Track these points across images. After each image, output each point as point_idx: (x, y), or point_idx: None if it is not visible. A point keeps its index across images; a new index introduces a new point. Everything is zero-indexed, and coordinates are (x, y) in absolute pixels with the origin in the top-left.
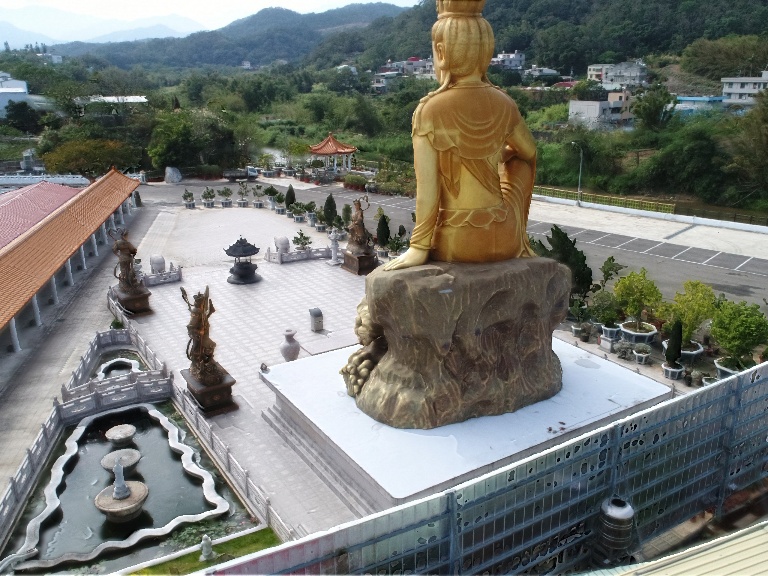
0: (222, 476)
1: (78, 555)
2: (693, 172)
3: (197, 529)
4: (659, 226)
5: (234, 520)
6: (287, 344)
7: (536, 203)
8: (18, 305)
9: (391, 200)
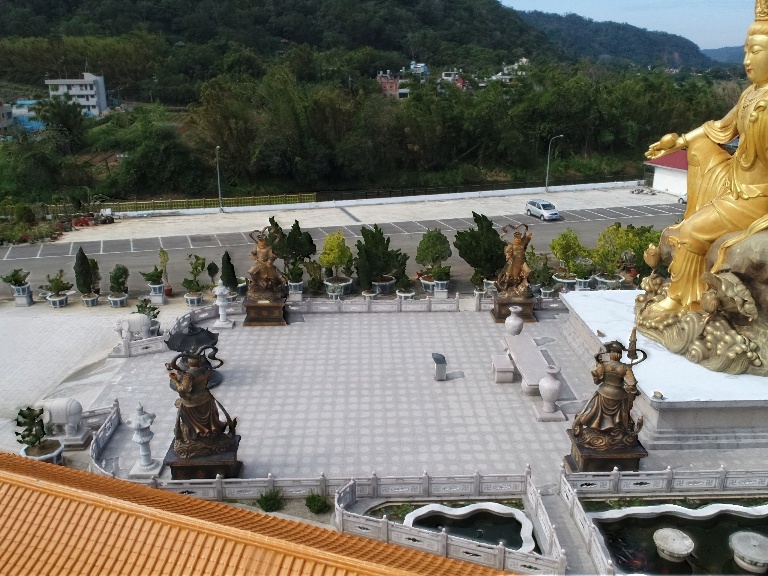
0: None
1: None
2: (176, 170)
3: None
4: (326, 214)
5: None
6: (559, 382)
7: (180, 218)
8: (300, 526)
9: (16, 251)
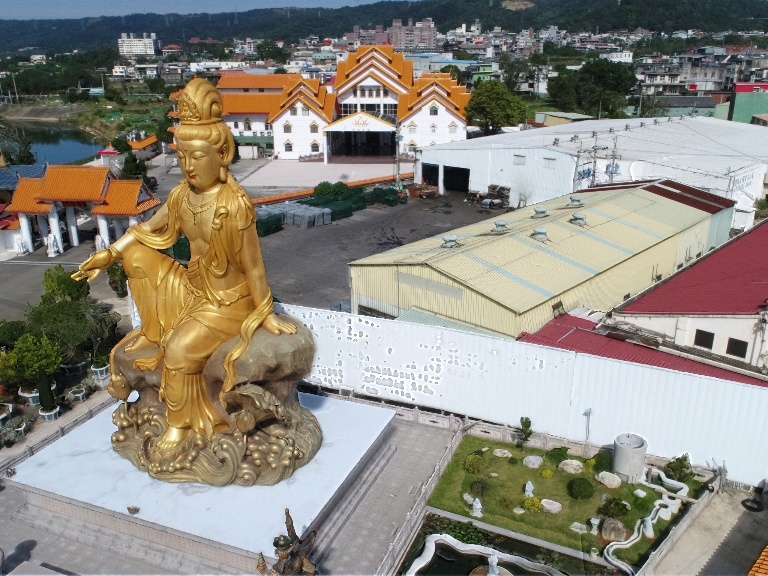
0: (400, 570)
1: (551, 570)
2: None
3: (463, 538)
4: None
5: (435, 530)
6: None
7: None
8: None
9: None
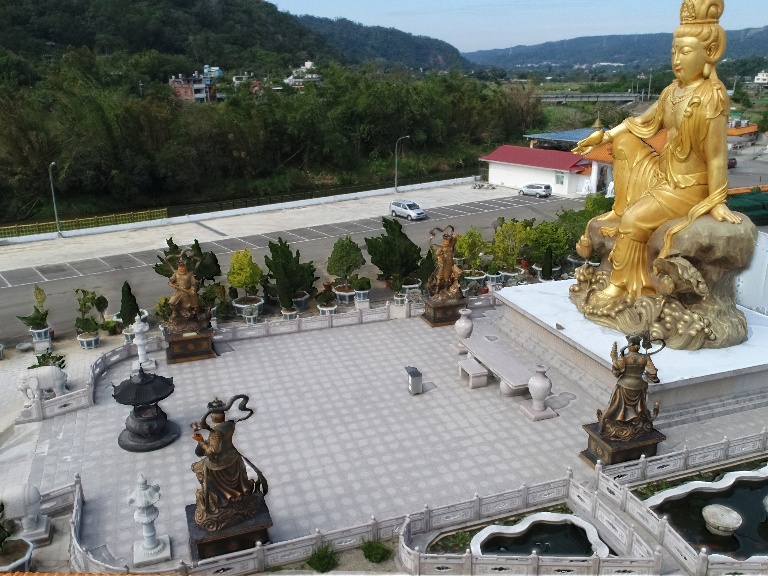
0: (767, 458)
1: None
2: None
3: None
4: (184, 230)
5: None
6: None
7: (12, 248)
8: None
9: None
